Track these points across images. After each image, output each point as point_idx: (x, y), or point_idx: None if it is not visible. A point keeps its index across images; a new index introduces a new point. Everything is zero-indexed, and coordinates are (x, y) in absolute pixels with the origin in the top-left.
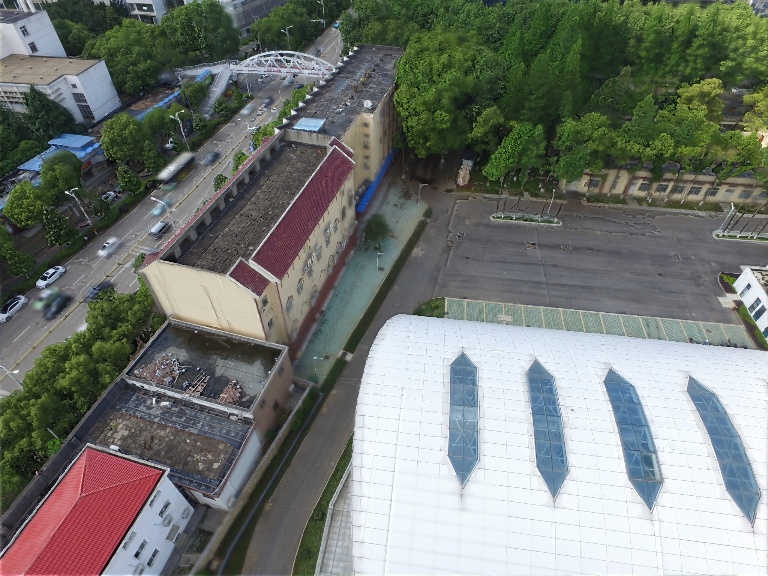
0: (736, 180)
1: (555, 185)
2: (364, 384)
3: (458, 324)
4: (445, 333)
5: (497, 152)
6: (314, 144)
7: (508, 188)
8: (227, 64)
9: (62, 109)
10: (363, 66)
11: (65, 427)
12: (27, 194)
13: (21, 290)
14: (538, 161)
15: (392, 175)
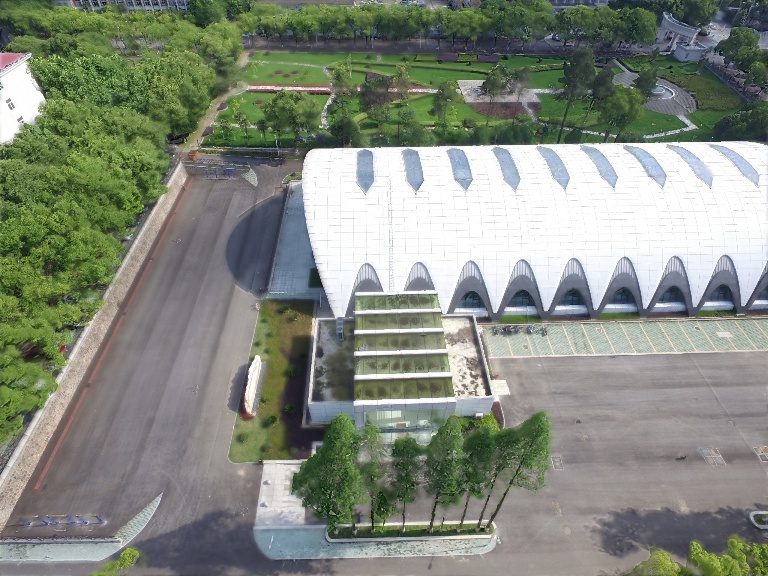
0: None
1: None
2: None
3: None
4: None
5: None
6: None
7: None
8: None
9: None
10: None
11: None
12: None
13: None
14: None
15: None
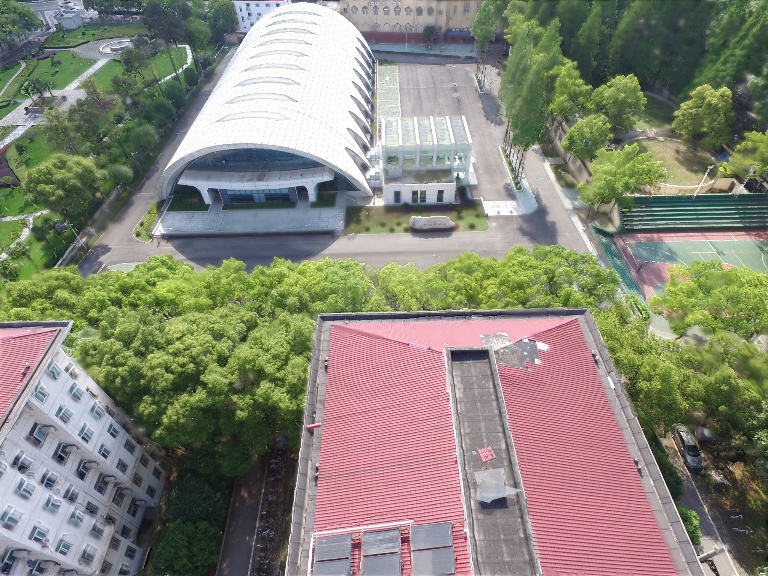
0: None
1: None
2: None
3: None
4: (334, 19)
5: None
6: None
7: None
8: None
9: None
10: None
11: None
12: None
13: None
14: (477, 26)
15: None
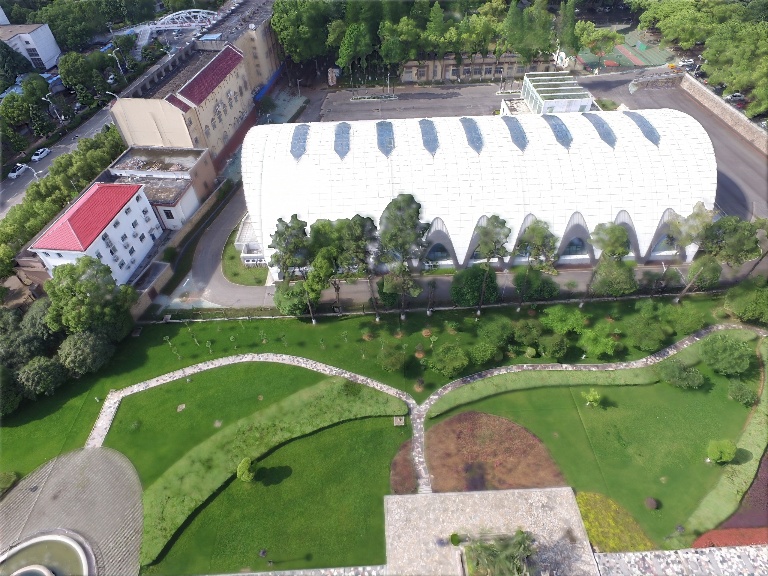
0: (511, 59)
1: (398, 79)
2: (247, 135)
3: None
4: None
5: (341, 46)
6: (215, 49)
7: (364, 84)
8: (147, 25)
9: (23, 56)
10: (250, 8)
11: (78, 191)
12: (15, 99)
13: (22, 162)
14: (367, 48)
15: (282, 85)
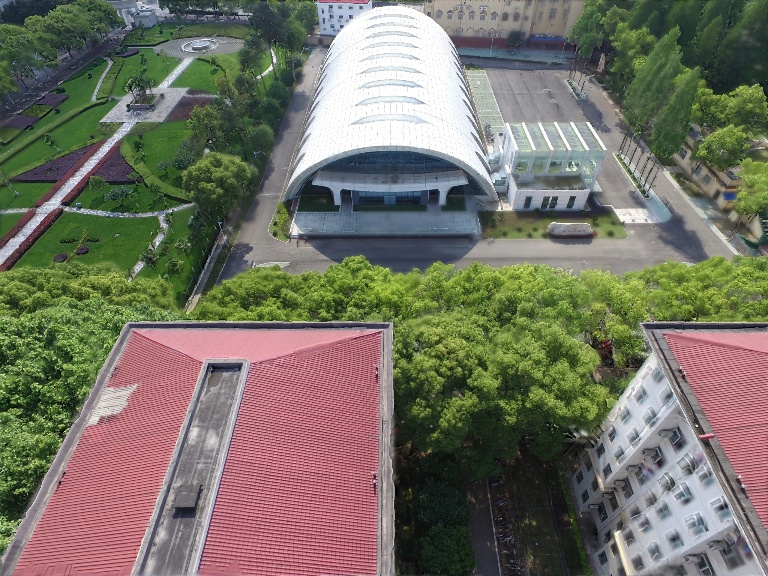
0: None
1: None
2: None
3: (439, 32)
4: None
5: None
6: None
7: (609, 84)
8: None
9: None
10: None
11: None
12: None
13: None
14: (579, 33)
15: None
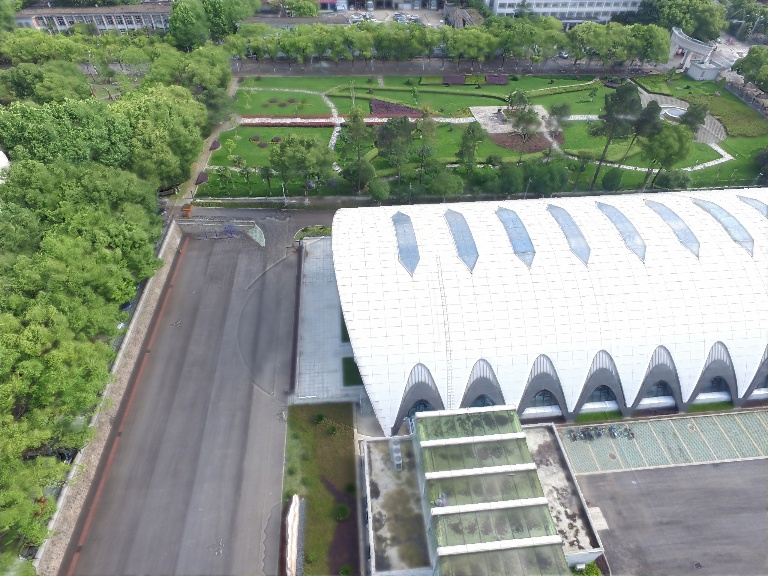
0: None
1: None
2: None
3: None
4: None
5: None
6: None
7: None
8: None
9: None
10: None
11: None
12: None
13: None
14: None
15: None
